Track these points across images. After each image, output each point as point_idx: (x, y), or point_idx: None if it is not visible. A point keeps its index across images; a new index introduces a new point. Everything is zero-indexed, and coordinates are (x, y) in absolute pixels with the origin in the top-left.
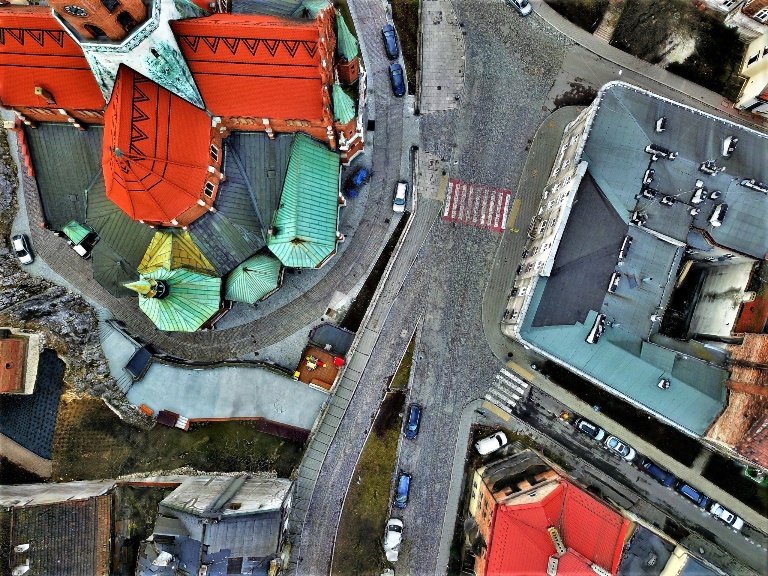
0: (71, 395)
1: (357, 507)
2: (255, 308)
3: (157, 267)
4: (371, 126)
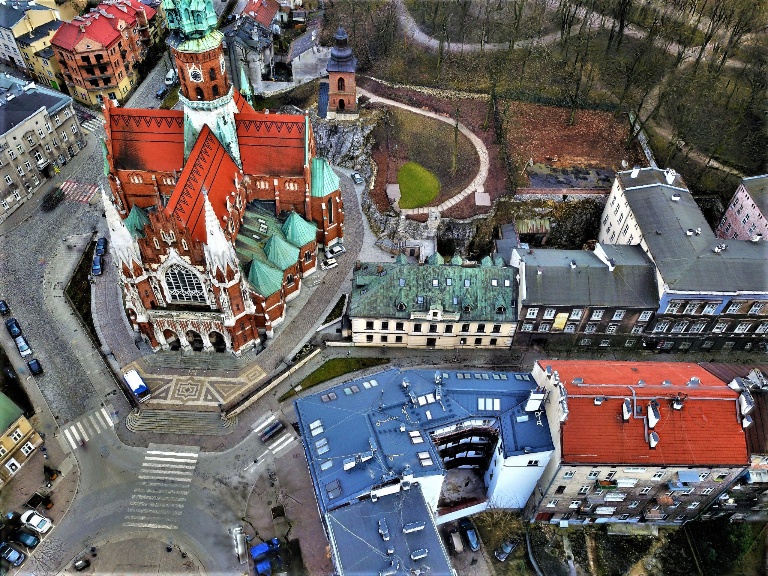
0: (314, 105)
1: None
2: None
3: None
4: None
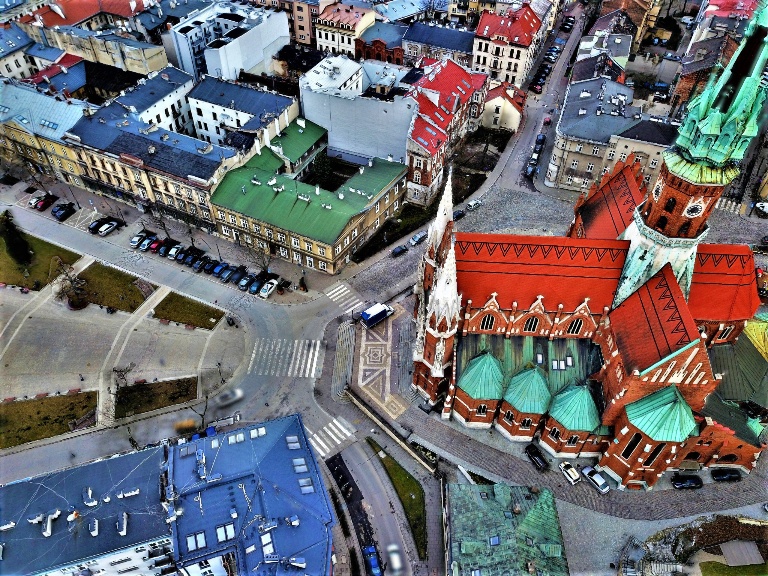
0: None
1: None
2: None
3: (765, 340)
4: None
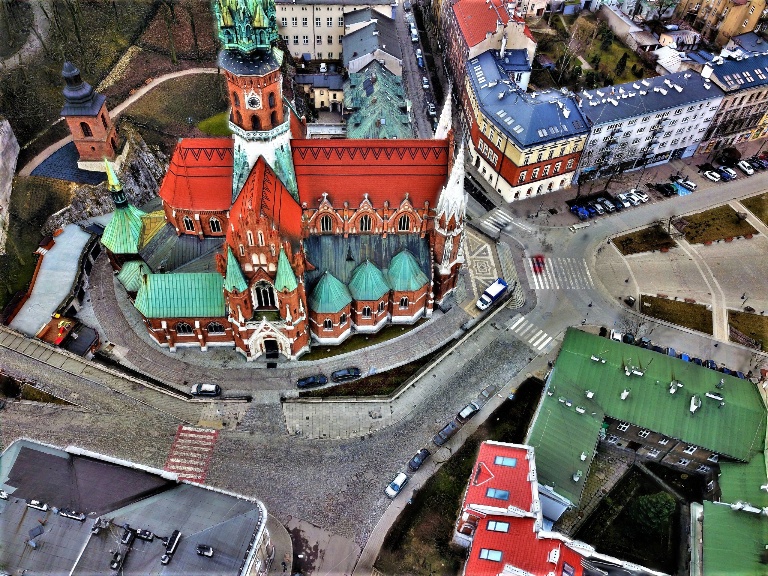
0: (74, 187)
1: None
2: (126, 298)
3: None
4: (271, 365)
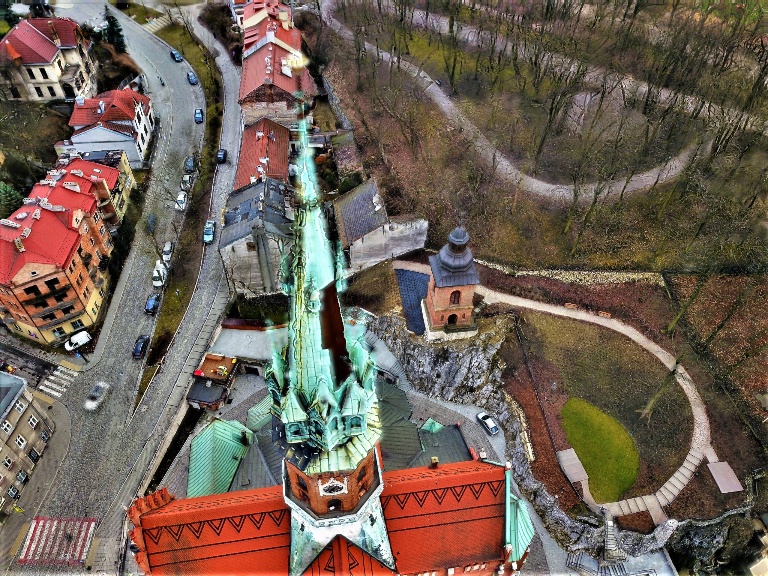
0: (396, 310)
1: (186, 287)
2: None
3: None
4: None
